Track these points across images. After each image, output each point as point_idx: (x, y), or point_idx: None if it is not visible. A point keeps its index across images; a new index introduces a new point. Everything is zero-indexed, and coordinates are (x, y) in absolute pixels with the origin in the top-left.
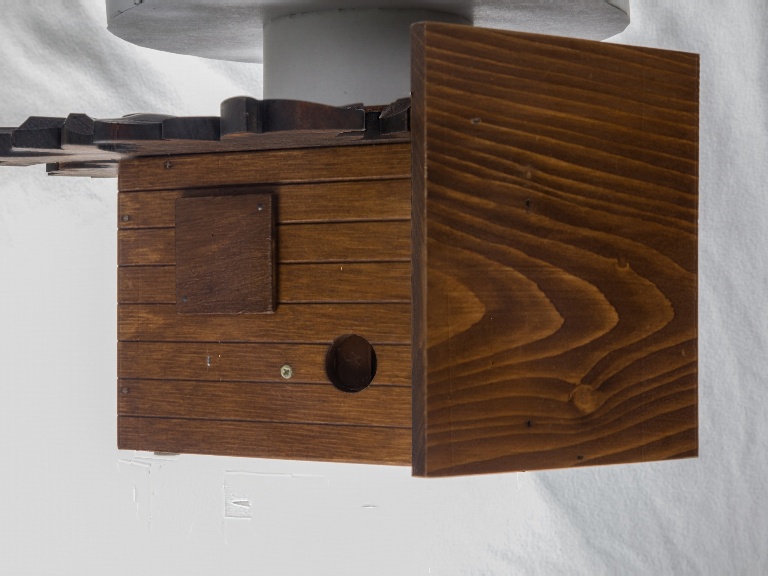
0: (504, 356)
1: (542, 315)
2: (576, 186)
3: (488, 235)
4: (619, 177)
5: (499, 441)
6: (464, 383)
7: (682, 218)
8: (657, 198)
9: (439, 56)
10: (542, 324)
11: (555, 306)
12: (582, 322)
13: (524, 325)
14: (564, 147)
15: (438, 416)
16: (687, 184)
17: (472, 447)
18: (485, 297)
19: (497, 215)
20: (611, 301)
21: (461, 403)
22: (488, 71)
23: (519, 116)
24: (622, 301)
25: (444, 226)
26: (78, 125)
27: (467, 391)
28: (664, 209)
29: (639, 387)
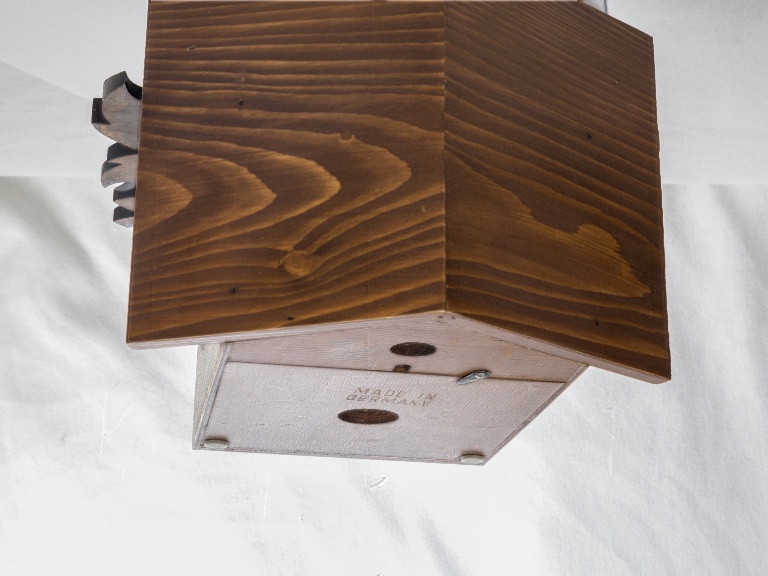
0: (210, 234)
1: (252, 194)
2: (294, 79)
3: (198, 135)
4: (344, 62)
5: (201, 308)
6: (168, 260)
7: (423, 83)
8: (390, 71)
9: (160, 8)
10: (252, 202)
11: (267, 184)
12: (297, 195)
13: (232, 205)
14: (281, 49)
15: (140, 290)
16: (429, 51)
17: (172, 314)
18: (193, 186)
19: (209, 118)
20: (332, 172)
21: (164, 277)
22: (206, 7)
23: (235, 35)
24: (345, 170)
25: (156, 135)
26: (126, 186)
27: (170, 267)
28: (399, 79)
29: (365, 247)
